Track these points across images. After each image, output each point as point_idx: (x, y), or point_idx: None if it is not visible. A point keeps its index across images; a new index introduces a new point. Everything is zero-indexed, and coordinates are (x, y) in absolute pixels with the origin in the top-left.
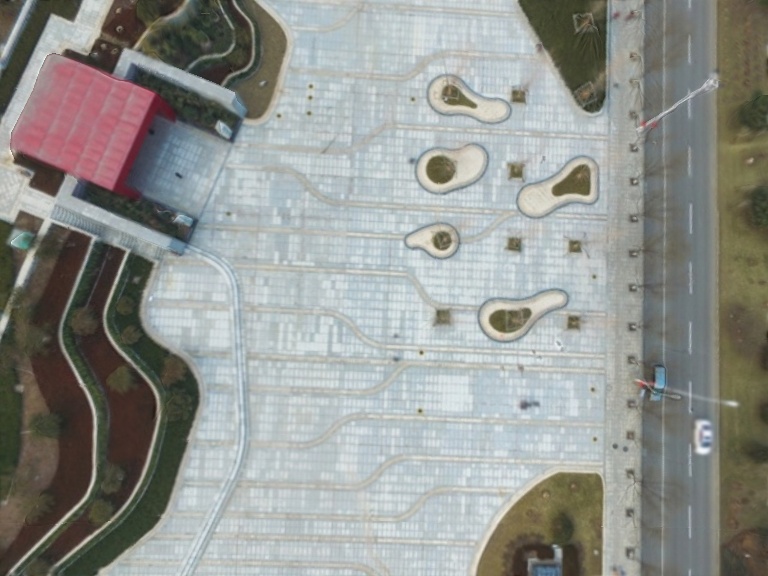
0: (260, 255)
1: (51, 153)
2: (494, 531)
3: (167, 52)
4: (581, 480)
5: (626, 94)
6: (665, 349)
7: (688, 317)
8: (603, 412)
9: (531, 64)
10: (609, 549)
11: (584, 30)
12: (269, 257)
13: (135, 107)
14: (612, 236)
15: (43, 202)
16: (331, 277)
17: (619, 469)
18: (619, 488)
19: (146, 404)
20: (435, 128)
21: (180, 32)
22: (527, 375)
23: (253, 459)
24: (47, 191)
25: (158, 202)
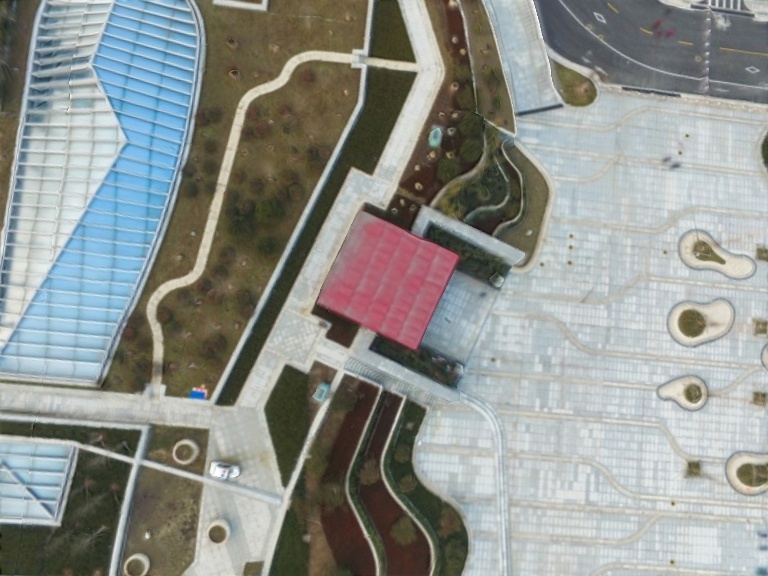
0: (522, 402)
1: (358, 310)
2: None
3: (459, 209)
4: None
5: None
6: None
7: None
8: None
9: None
10: None
11: None
12: (531, 404)
13: (440, 268)
14: None
15: (337, 353)
16: (589, 426)
17: None
18: None
19: (421, 553)
20: (685, 281)
21: (468, 188)
22: None
23: None
24: (342, 342)
25: (428, 346)
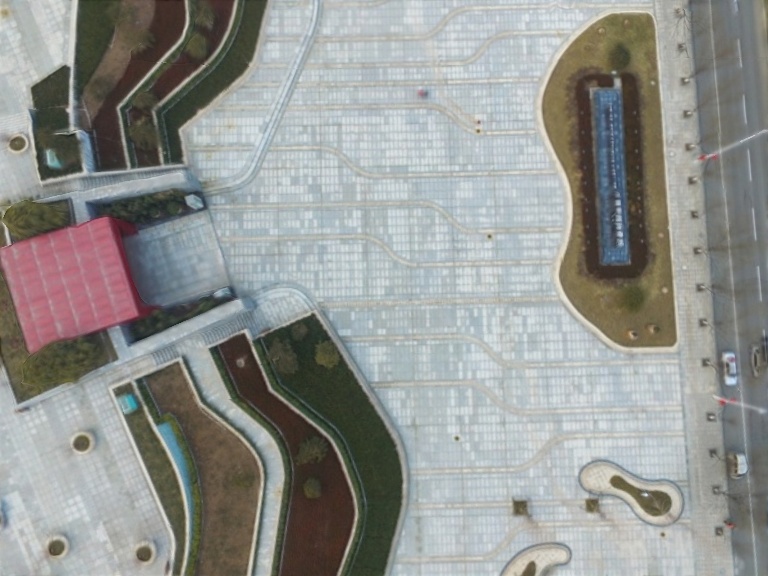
0: None
1: None
2: (556, 66)
3: None
4: (633, 18)
5: None
6: None
7: None
8: None
9: None
10: (665, 79)
11: None
12: None
13: None
14: None
15: None
16: None
17: (668, 8)
18: (670, 24)
19: None
20: None
21: None
22: None
23: (327, 18)
24: None
25: None
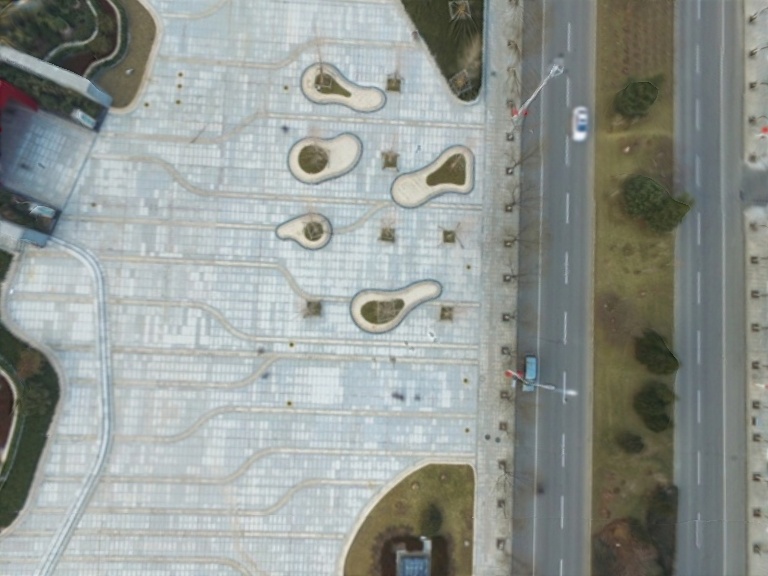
0: (126, 247)
1: None
2: (363, 523)
3: (20, 39)
4: (452, 471)
5: (503, 82)
6: (540, 339)
7: (563, 307)
8: (476, 403)
9: (407, 52)
10: (480, 540)
11: (458, 17)
12: (136, 249)
13: None
14: (487, 226)
15: None
16: (199, 269)
17: (491, 460)
18: (491, 479)
19: (2, 399)
20: (308, 117)
21: (35, 18)
22: (399, 366)
23: (117, 454)
24: None
25: (20, 193)
